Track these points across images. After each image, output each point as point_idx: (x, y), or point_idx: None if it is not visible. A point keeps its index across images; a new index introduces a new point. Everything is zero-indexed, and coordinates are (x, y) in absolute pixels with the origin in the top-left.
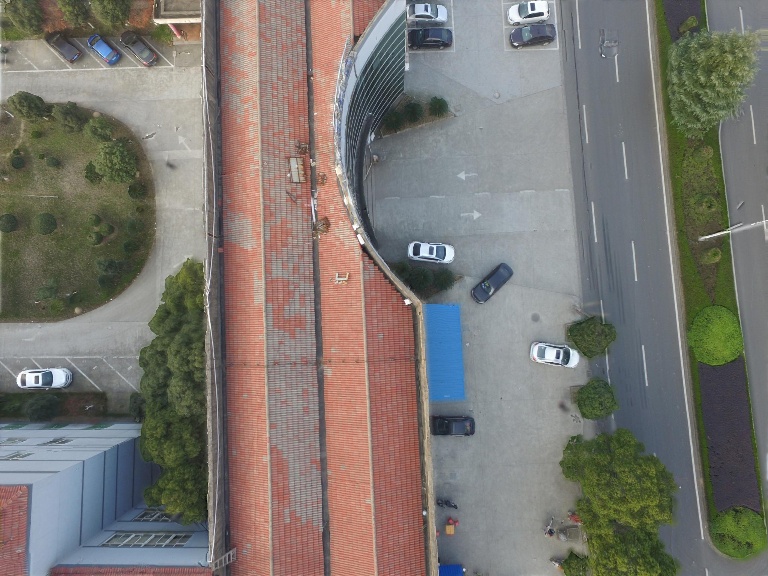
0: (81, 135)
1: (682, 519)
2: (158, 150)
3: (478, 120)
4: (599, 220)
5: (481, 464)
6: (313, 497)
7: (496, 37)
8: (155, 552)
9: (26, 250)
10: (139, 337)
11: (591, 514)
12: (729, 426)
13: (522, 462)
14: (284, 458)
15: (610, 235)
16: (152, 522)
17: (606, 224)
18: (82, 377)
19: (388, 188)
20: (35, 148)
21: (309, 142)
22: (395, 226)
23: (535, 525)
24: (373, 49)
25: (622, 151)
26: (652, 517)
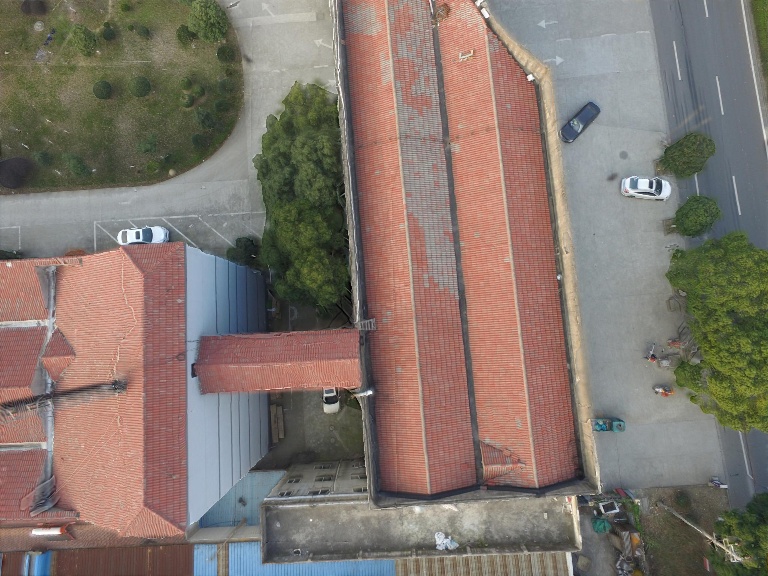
0: (167, 7)
1: None
2: (242, 17)
3: None
4: (682, 58)
5: None
6: (448, 267)
7: None
8: None
9: (119, 118)
10: (233, 195)
11: (706, 311)
12: None
13: (619, 295)
14: (420, 226)
15: (694, 72)
16: None
17: (689, 62)
18: (179, 235)
19: None
20: (123, 22)
21: None
22: None
23: (635, 356)
24: None
25: None
26: None
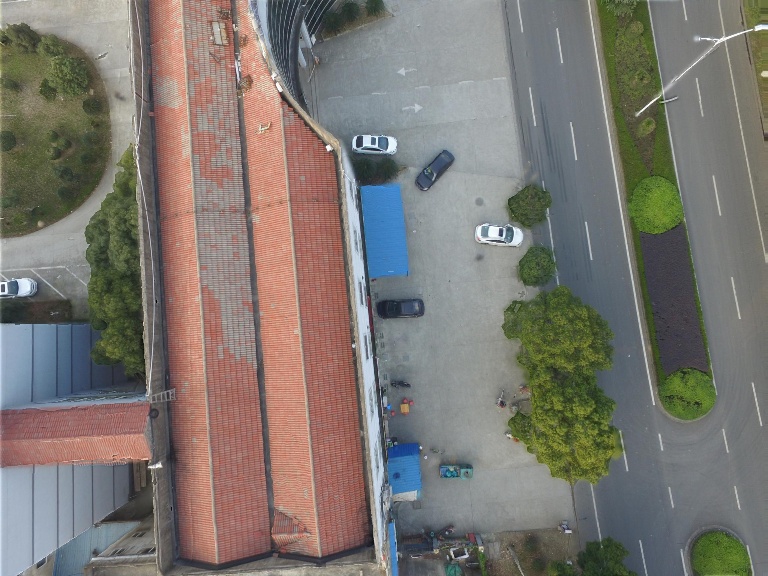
0: (37, 59)
1: (632, 386)
2: (111, 69)
3: (415, 18)
4: (537, 104)
5: (433, 345)
6: (246, 336)
7: None
8: (101, 401)
9: None
10: None
11: (530, 366)
12: (673, 291)
13: (472, 341)
14: (216, 298)
15: (548, 118)
16: (106, 393)
17: (544, 108)
18: (47, 286)
19: (331, 88)
20: None
21: (231, 8)
22: (339, 124)
23: (488, 401)
24: None
25: (556, 37)
26: (587, 358)
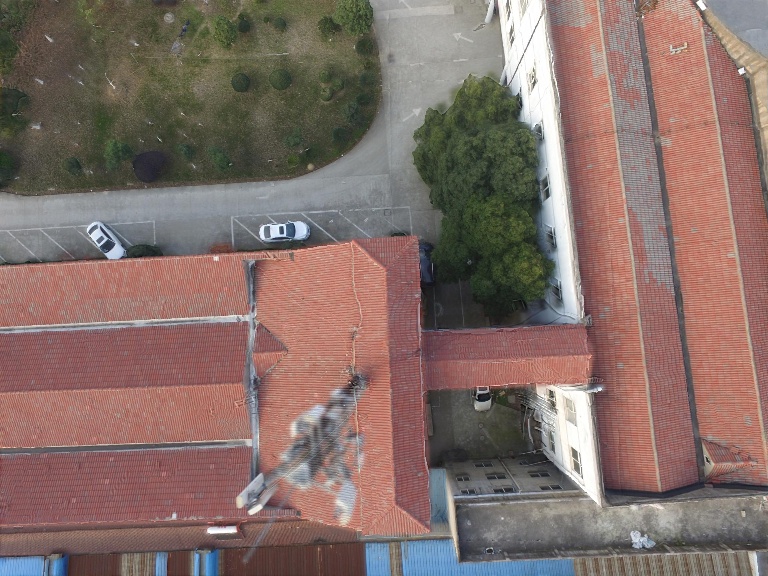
0: None
1: None
2: (378, 10)
3: None
4: None
5: None
6: (664, 262)
7: None
8: (501, 328)
9: (256, 111)
10: (373, 190)
11: None
12: None
13: None
14: (638, 221)
15: None
16: None
17: None
18: (319, 231)
19: None
20: (257, 14)
21: None
22: None
23: None
24: None
25: None
26: None
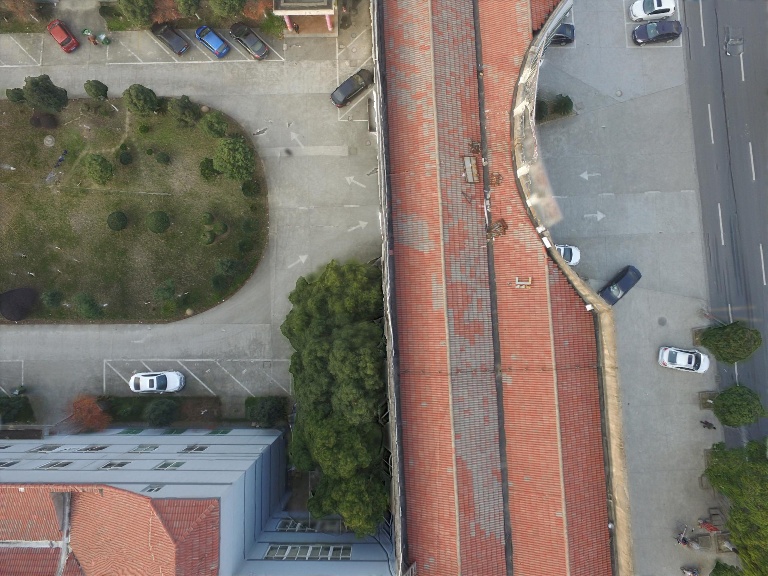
0: (190, 130)
1: None
2: (270, 146)
3: (600, 119)
4: (726, 222)
5: None
6: (495, 509)
7: (618, 33)
8: (327, 566)
9: (134, 249)
10: (253, 339)
11: (747, 524)
12: None
13: (651, 469)
14: (468, 469)
15: (738, 238)
16: (299, 533)
17: (733, 226)
18: (195, 380)
19: None
20: (142, 143)
21: (481, 140)
22: None
23: (664, 533)
24: (541, 44)
25: (749, 152)
26: None
